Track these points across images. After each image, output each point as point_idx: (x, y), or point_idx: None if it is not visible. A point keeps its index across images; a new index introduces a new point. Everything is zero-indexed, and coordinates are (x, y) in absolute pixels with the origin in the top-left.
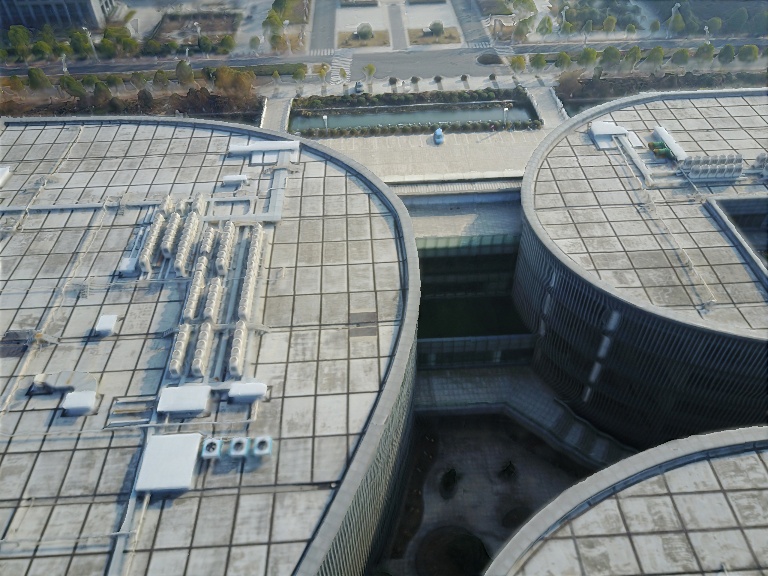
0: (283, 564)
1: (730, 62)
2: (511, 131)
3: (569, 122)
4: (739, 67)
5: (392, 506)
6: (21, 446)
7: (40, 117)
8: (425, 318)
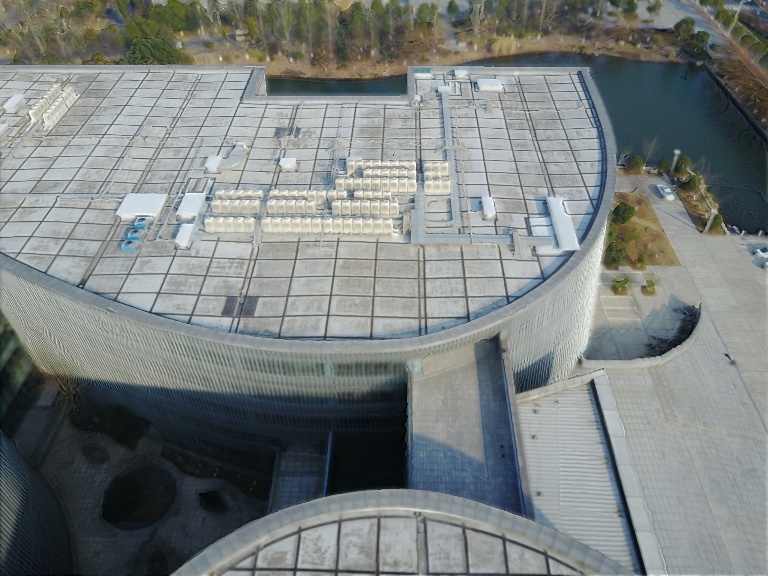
0: (37, 261)
1: None
2: None
3: None
4: None
5: (177, 423)
6: (194, 151)
7: None
8: (372, 450)
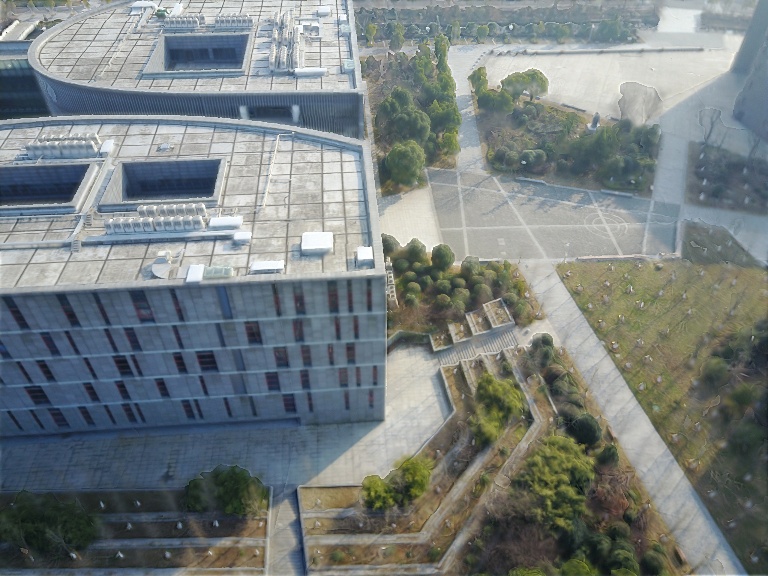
0: None
1: (397, 1)
2: None
3: (122, 1)
4: (409, 6)
5: None
6: None
7: None
8: None
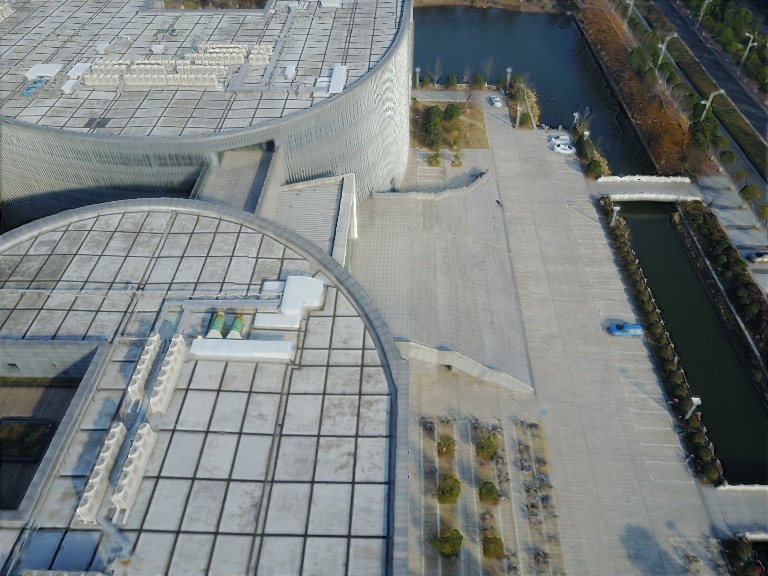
0: None
1: None
2: (676, 429)
3: (328, 259)
4: None
5: None
6: None
7: (409, 1)
8: None
